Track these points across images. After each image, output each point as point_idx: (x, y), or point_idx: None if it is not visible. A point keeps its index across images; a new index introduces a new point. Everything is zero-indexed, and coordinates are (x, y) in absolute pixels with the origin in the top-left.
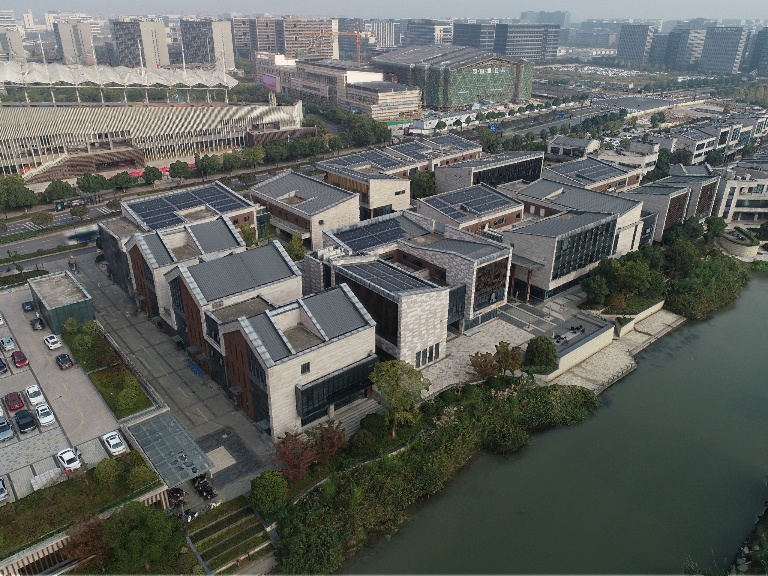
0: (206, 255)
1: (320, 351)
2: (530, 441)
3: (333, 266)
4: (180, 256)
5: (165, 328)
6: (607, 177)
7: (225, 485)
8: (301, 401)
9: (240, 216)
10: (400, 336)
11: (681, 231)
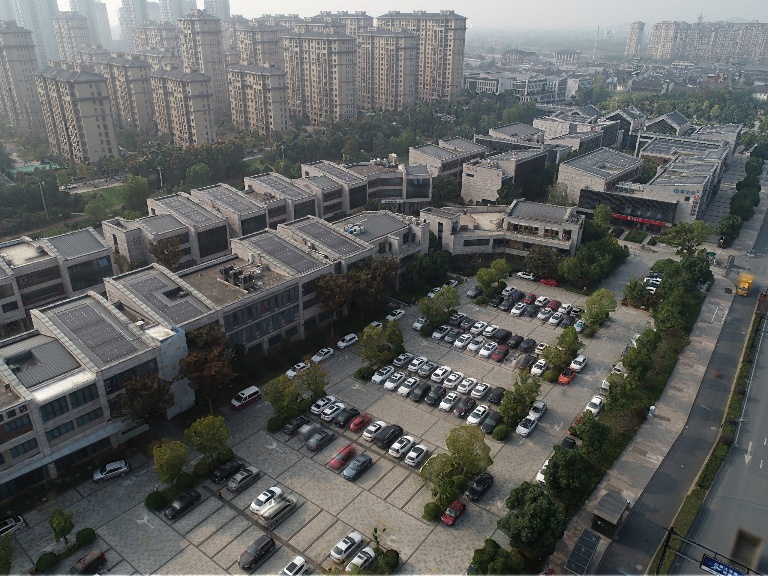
0: None
1: None
2: None
3: None
4: None
5: None
6: (495, 157)
7: None
8: None
9: None
10: None
11: None
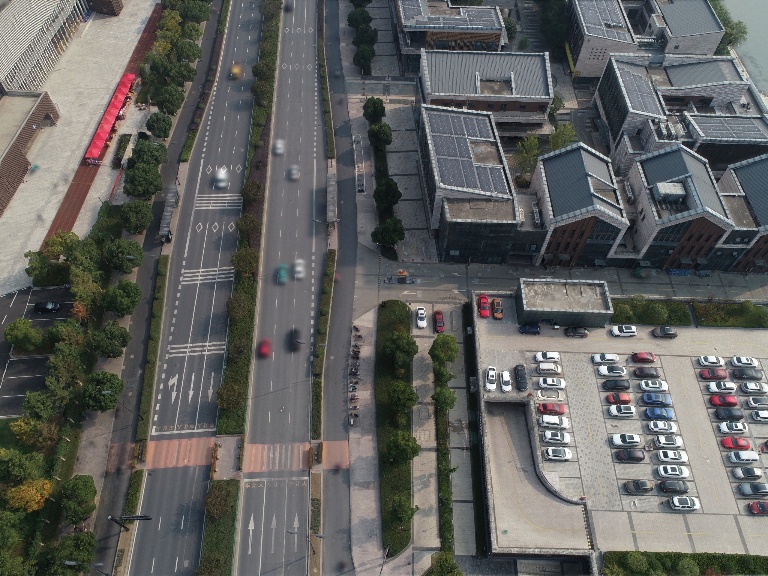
0: (663, 189)
1: None
2: None
3: (702, 140)
4: None
5: (606, 264)
6: None
7: None
8: None
9: None
10: None
11: None
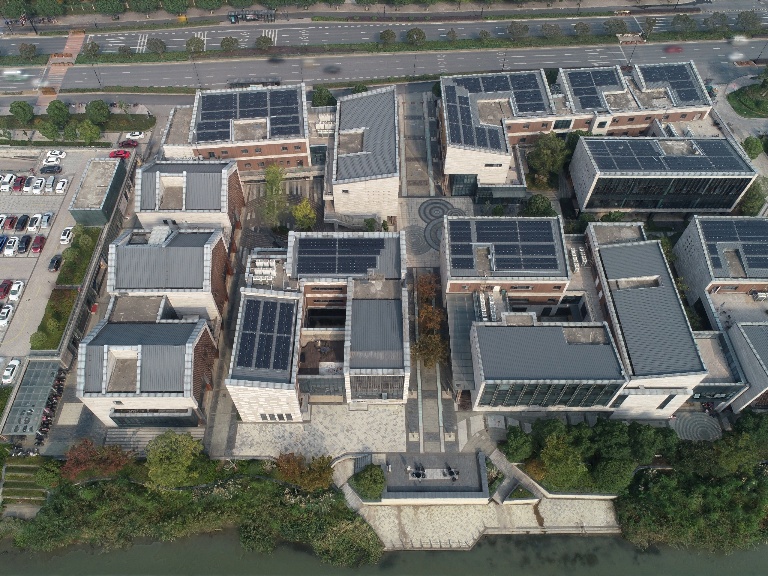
0: (158, 228)
1: (130, 398)
2: (278, 550)
3: (242, 294)
4: (169, 202)
5: None
6: None
7: (54, 440)
8: (113, 420)
9: (290, 144)
10: (234, 402)
11: (767, 424)
